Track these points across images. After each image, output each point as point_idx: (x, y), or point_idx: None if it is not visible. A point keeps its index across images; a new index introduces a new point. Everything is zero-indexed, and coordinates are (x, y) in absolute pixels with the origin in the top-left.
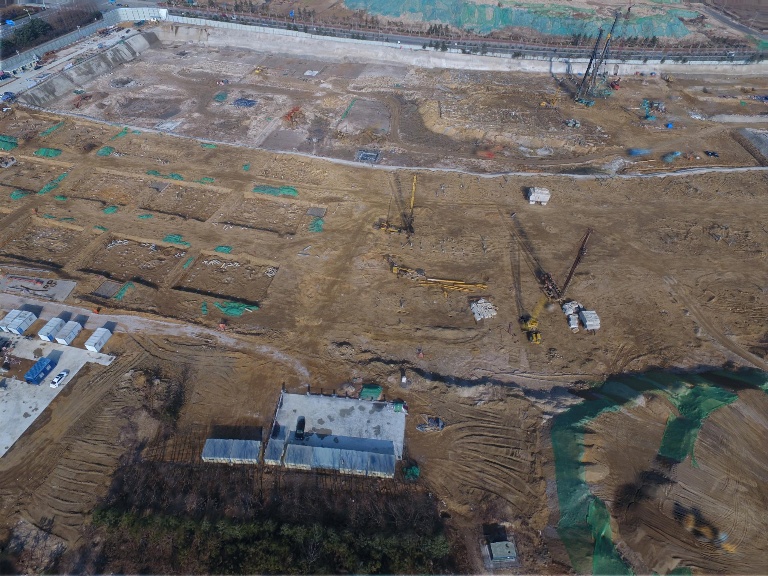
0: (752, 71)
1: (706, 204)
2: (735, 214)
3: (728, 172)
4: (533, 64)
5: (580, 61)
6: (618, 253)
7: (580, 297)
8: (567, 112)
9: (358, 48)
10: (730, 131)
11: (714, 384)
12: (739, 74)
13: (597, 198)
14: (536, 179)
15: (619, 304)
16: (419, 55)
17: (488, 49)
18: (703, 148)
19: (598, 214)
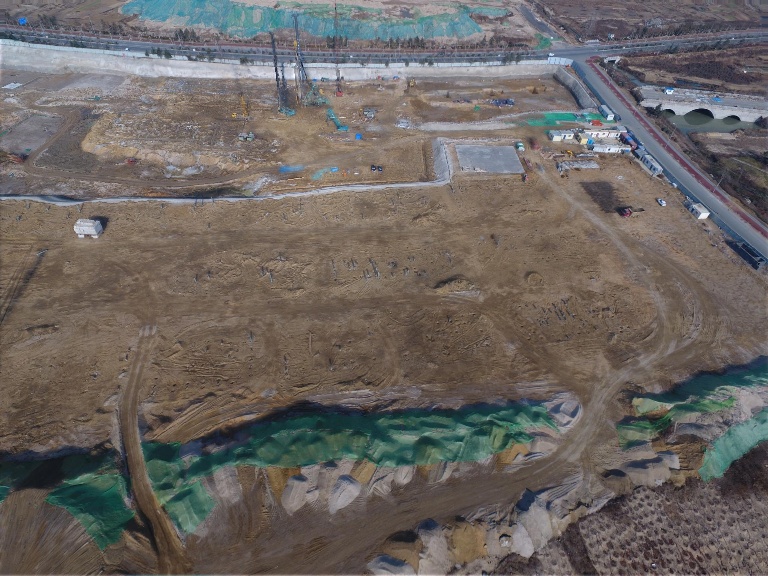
0: (511, 72)
1: (295, 231)
2: (318, 242)
3: (361, 191)
4: (264, 70)
5: (315, 66)
6: (121, 297)
7: (7, 358)
8: (257, 124)
9: (78, 57)
10: (424, 141)
11: (16, 480)
12: (496, 76)
13: (170, 227)
14: (120, 206)
15: (47, 366)
16: (141, 63)
17: (221, 55)
18: (375, 162)
19: (150, 248)
